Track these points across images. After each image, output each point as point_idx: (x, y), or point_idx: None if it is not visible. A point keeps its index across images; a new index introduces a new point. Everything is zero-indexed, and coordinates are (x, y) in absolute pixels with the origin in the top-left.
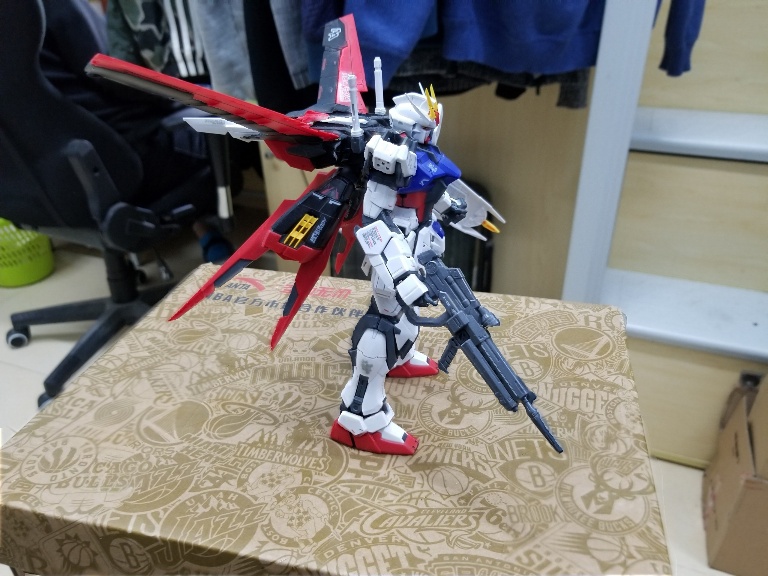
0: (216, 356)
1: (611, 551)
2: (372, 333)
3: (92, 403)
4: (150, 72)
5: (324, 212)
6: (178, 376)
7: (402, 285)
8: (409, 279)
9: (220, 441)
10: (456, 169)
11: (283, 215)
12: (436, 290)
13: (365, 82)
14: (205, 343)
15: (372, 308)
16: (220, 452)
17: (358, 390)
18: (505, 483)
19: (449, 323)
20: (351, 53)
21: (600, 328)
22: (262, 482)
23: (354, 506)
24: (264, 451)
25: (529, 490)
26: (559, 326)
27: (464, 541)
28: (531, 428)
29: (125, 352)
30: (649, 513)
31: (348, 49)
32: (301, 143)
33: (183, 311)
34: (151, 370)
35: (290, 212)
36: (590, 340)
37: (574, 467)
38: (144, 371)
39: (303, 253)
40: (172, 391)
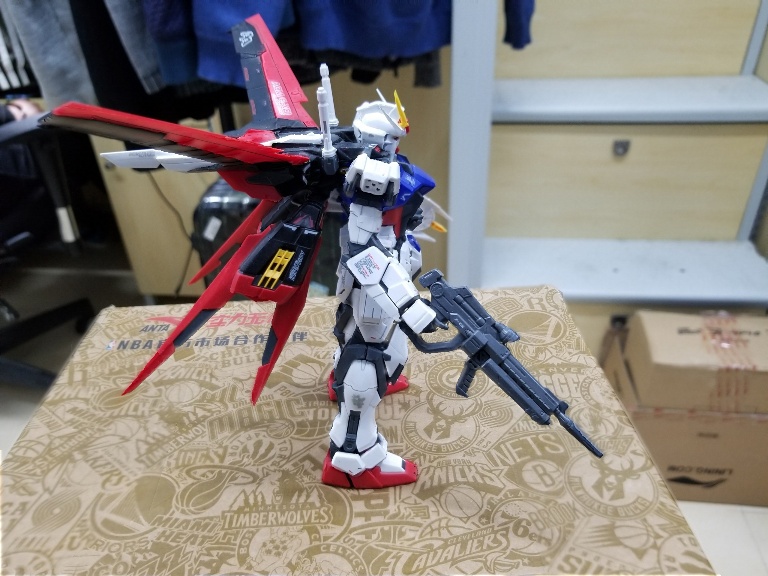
0: (158, 415)
1: (639, 536)
2: (360, 364)
3: (23, 506)
4: (126, 115)
5: (300, 244)
6: (121, 449)
7: (409, 313)
8: (416, 306)
9: (199, 516)
10: (429, 177)
11: (252, 254)
12: (445, 312)
13: (301, 90)
14: (139, 403)
15: (355, 338)
16: (204, 529)
17: (350, 427)
18: (517, 490)
19: (466, 346)
20: (273, 58)
21: (545, 309)
22: (266, 553)
23: (377, 554)
24: (255, 516)
25: (542, 492)
26: (507, 314)
27: (502, 563)
28: (520, 426)
29: (44, 433)
30: (657, 488)
31: (268, 54)
32: (264, 170)
33: (139, 381)
34: (85, 448)
35: (260, 249)
36: (541, 323)
37: (574, 457)
38: (76, 451)
39: (282, 293)
40: (120, 469)
